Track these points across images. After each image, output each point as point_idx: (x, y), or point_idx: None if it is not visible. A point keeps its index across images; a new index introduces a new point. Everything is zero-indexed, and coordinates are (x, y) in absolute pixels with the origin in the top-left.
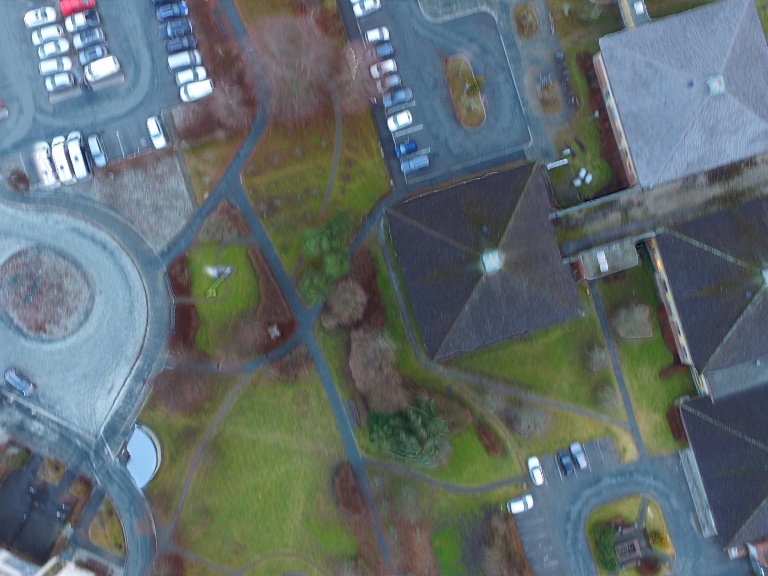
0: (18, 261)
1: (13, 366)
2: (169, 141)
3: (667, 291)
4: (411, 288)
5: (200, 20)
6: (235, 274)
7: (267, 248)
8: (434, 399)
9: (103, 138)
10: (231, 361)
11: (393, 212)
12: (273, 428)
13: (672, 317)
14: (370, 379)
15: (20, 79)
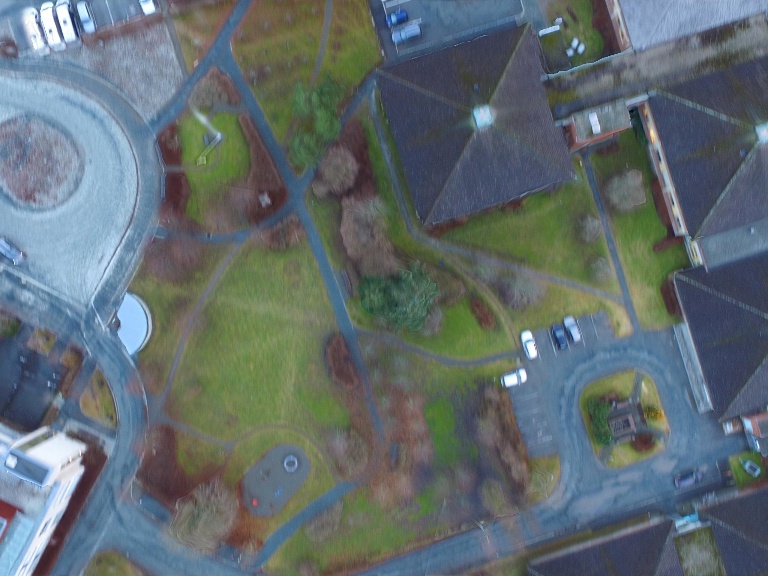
0: (7, 129)
1: (3, 235)
2: (158, 8)
3: (660, 161)
4: (402, 151)
5: None
6: (225, 141)
7: (257, 116)
8: (426, 269)
9: (92, 5)
10: (222, 230)
11: (384, 73)
12: (264, 298)
13: (666, 188)
14: (361, 245)
15: None
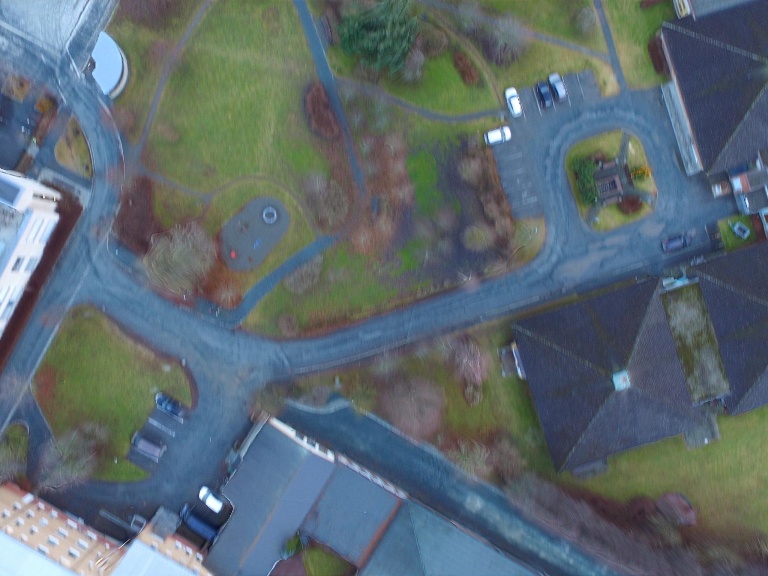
0: None
1: None
2: None
3: None
4: None
5: None
6: None
7: None
8: None
9: None
10: None
11: None
12: (243, 46)
13: None
14: None
15: None
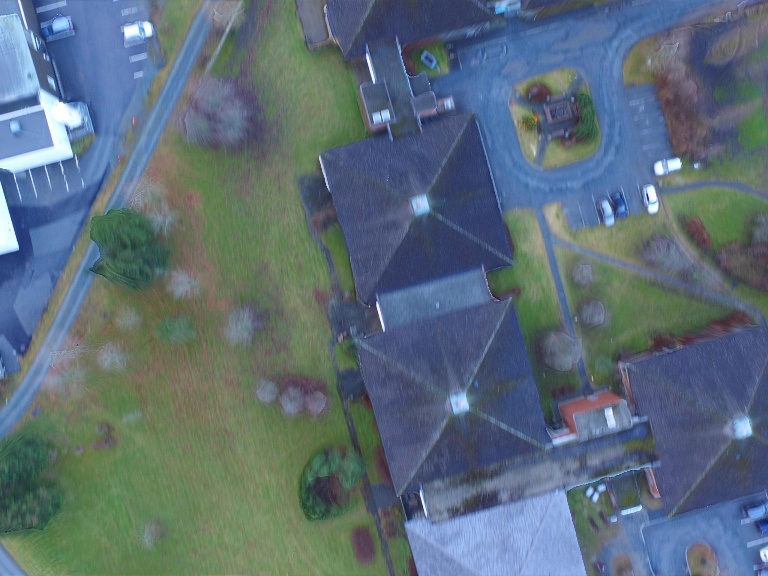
0: None
1: None
2: None
3: None
4: None
5: None
6: None
7: None
8: (761, 280)
9: None
10: None
11: None
12: None
13: None
14: None
15: None
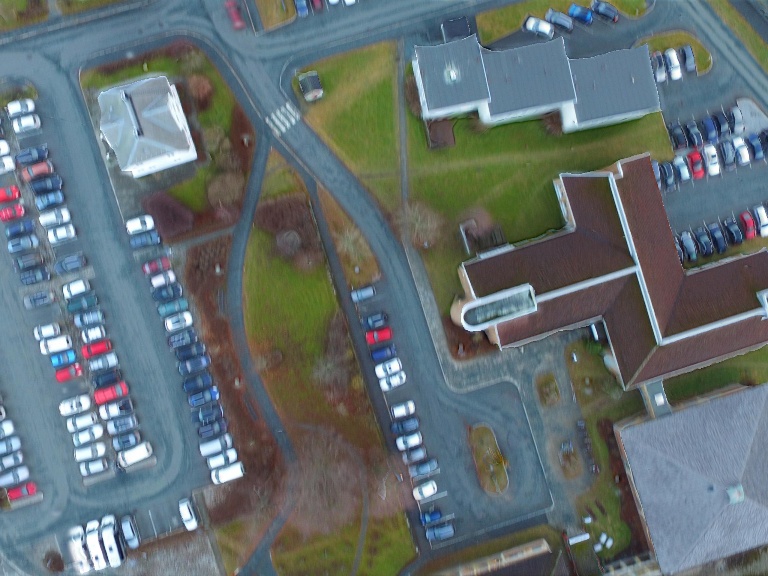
0: None
1: None
2: (200, 521)
3: None
4: None
5: (231, 402)
6: None
7: None
8: None
9: (136, 517)
10: None
11: None
12: None
13: None
14: None
15: (55, 462)
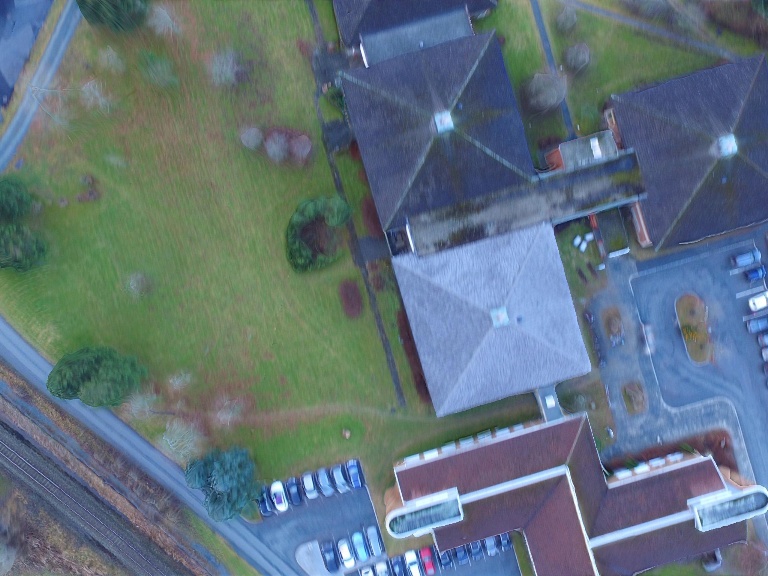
0: None
1: None
2: None
3: None
4: None
5: None
6: None
7: None
8: (745, 21)
9: None
10: None
11: None
12: None
13: None
14: None
15: None
